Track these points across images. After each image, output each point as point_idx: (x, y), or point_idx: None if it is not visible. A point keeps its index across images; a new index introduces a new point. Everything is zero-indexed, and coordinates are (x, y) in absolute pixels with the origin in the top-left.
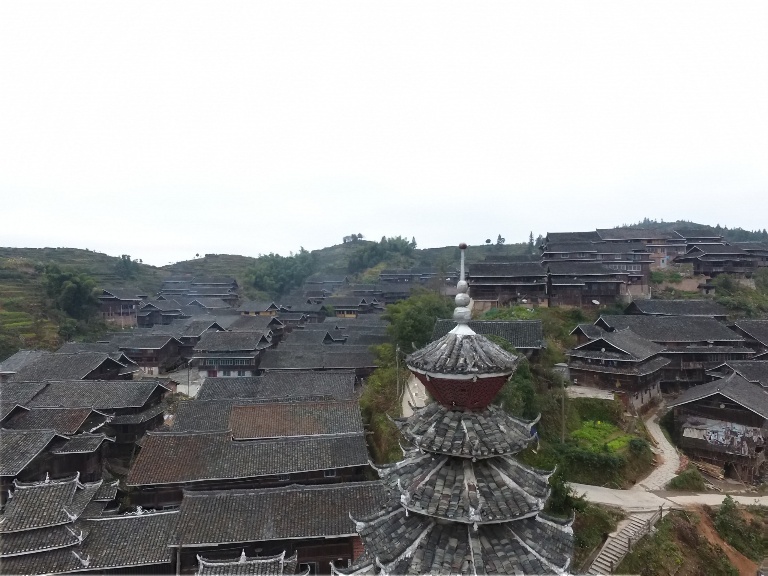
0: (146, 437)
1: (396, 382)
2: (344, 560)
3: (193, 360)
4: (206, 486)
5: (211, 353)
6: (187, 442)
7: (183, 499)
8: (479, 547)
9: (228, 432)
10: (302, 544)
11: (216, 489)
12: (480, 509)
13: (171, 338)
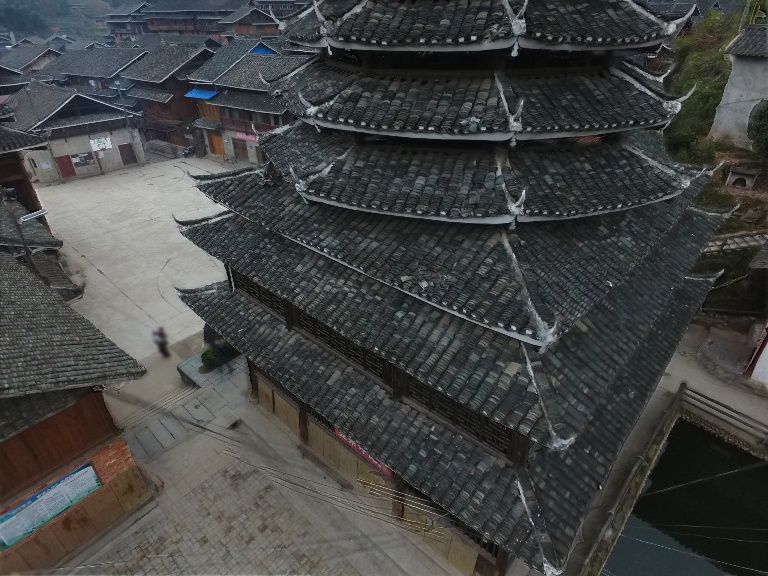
0: None
1: (743, 9)
2: None
3: None
4: None
5: None
6: None
7: None
8: None
9: None
10: None
11: None
12: None
13: None
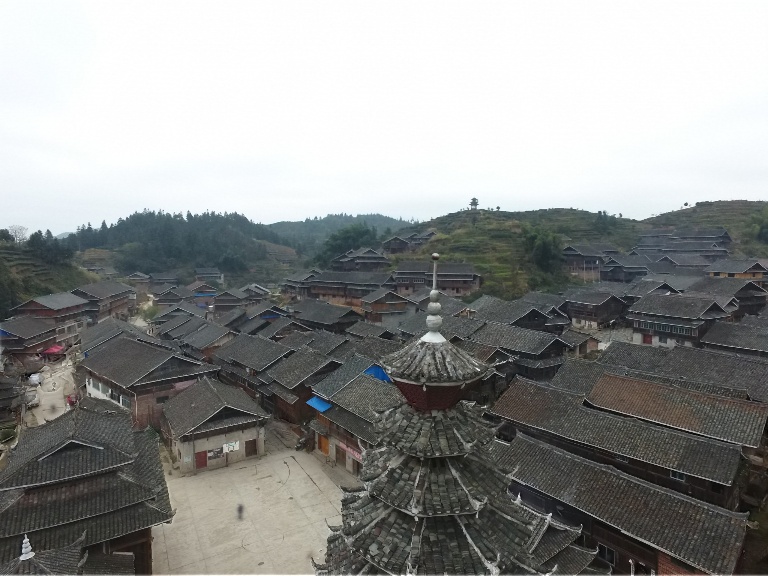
0: (515, 380)
1: None
2: (647, 567)
3: (627, 320)
4: (547, 436)
5: (647, 316)
6: (544, 393)
7: (515, 437)
8: (380, 514)
9: (581, 395)
10: (601, 525)
11: (556, 442)
12: (374, 483)
13: (611, 296)
